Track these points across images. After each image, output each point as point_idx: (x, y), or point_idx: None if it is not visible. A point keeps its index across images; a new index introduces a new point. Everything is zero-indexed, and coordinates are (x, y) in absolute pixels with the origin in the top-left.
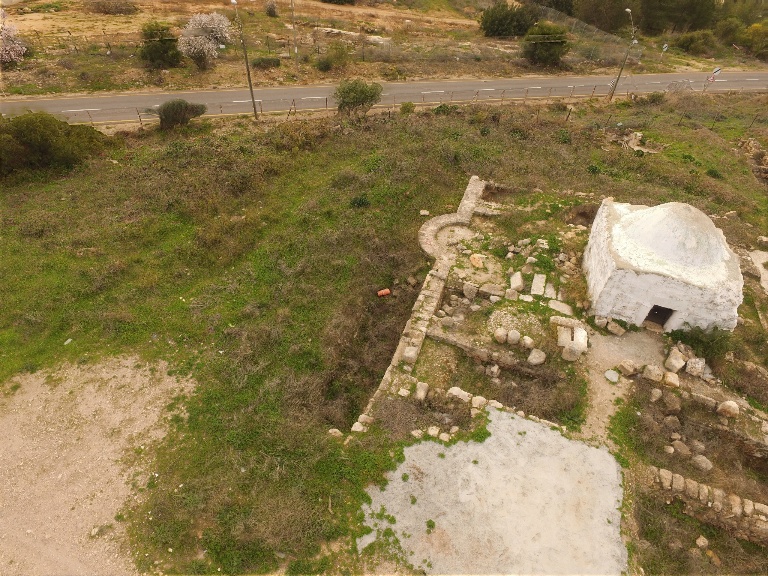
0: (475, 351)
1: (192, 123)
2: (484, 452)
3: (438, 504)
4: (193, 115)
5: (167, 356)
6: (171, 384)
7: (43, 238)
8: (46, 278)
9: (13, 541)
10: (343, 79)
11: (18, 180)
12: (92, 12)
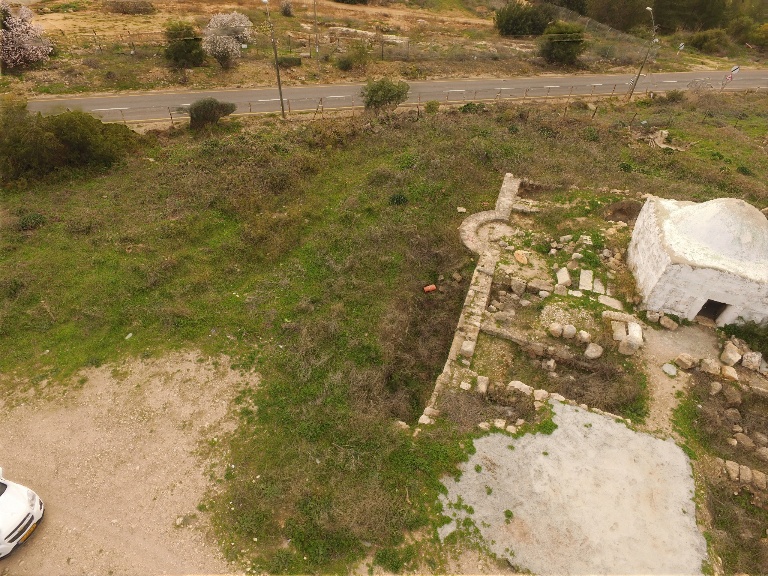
0: (530, 345)
1: (221, 122)
2: (553, 444)
3: (514, 494)
4: (223, 114)
5: (228, 350)
6: (236, 378)
7: (90, 235)
8: (99, 274)
9: (100, 530)
10: (371, 78)
11: (59, 178)
12: (111, 12)
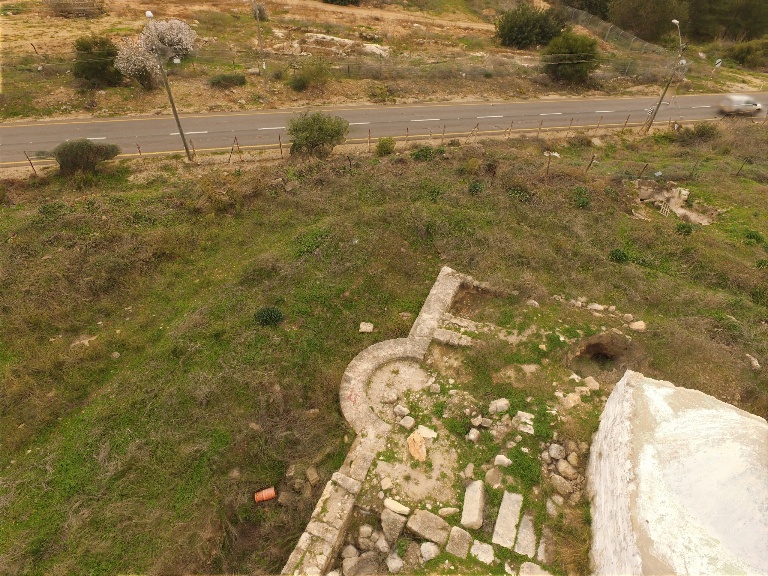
0: None
1: (104, 166)
2: None
3: None
4: (102, 158)
5: None
6: None
7: None
8: None
9: None
10: None
11: None
12: (50, 16)
